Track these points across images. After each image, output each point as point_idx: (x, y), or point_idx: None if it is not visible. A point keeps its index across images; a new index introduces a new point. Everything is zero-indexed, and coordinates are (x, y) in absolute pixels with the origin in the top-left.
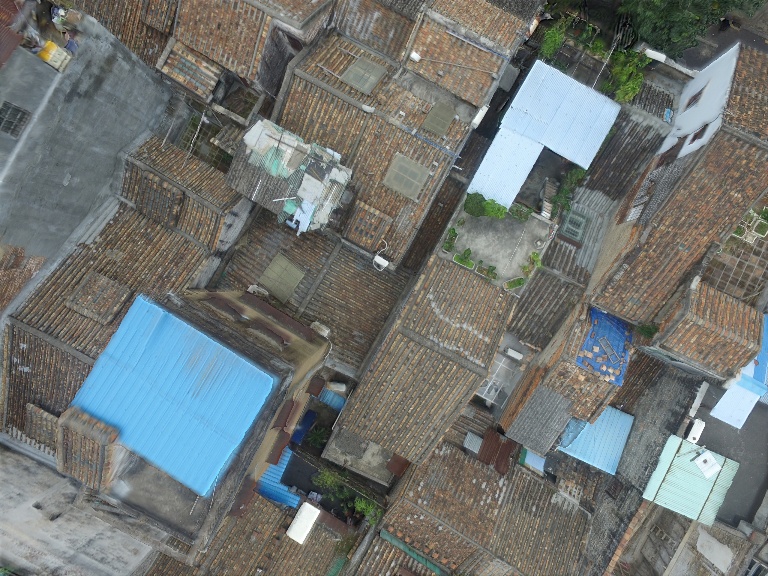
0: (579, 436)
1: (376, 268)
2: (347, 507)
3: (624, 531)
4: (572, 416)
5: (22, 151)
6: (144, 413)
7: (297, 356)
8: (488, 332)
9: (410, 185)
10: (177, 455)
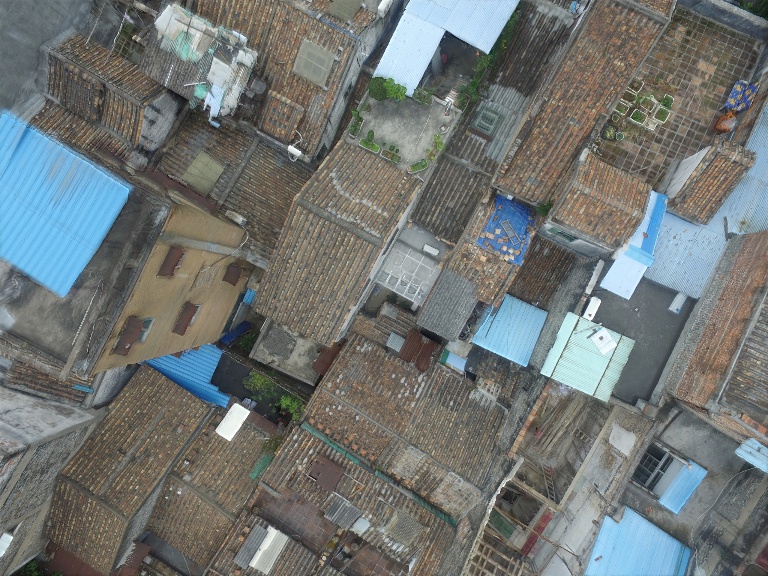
0: (493, 330)
1: (291, 159)
2: (281, 415)
3: (528, 413)
4: (478, 300)
5: None
6: (8, 222)
7: (184, 208)
8: (387, 208)
9: (319, 73)
10: (38, 261)
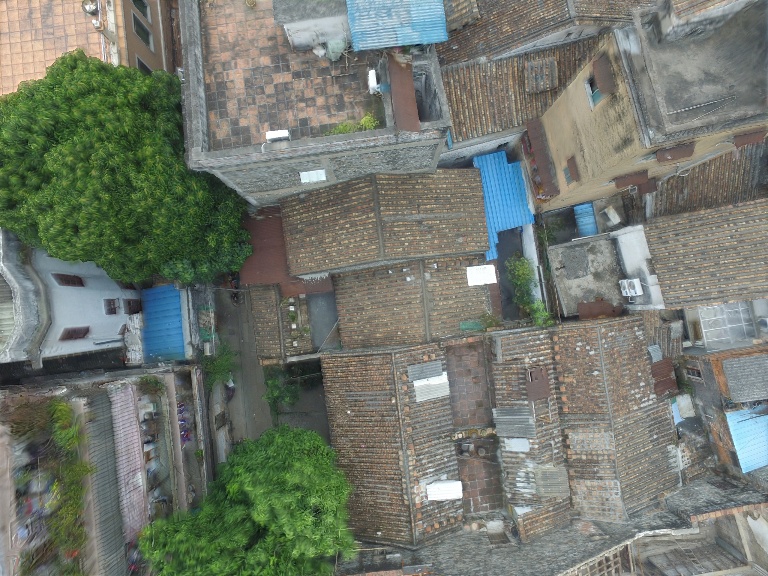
0: (747, 424)
1: None
2: None
3: (736, 506)
4: None
5: None
6: None
7: None
8: None
9: None
10: None
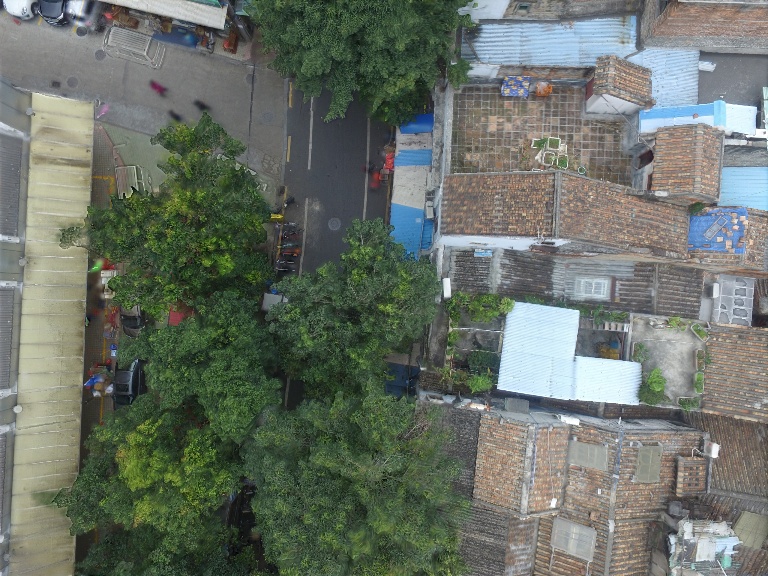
0: (759, 208)
1: None
2: None
3: None
4: None
5: None
6: None
7: None
8: None
9: None
10: None
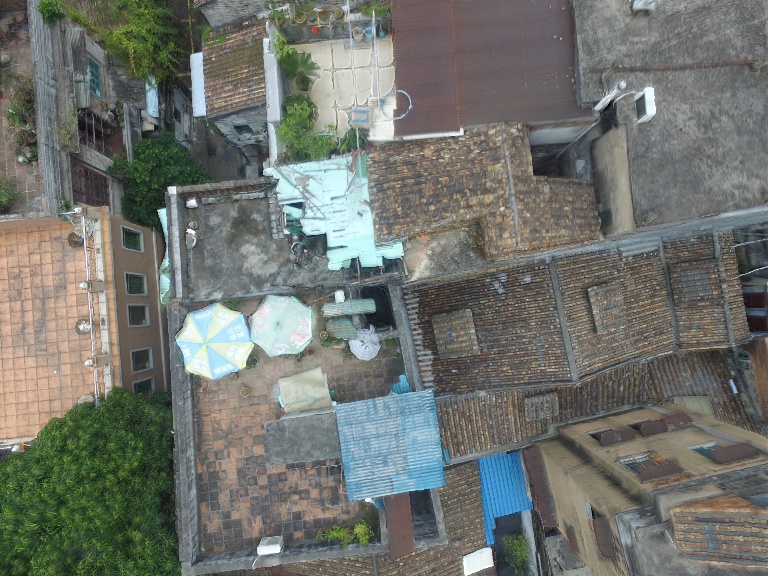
0: None
1: None
2: None
3: None
4: None
5: (765, 211)
6: None
7: None
8: None
9: None
10: None
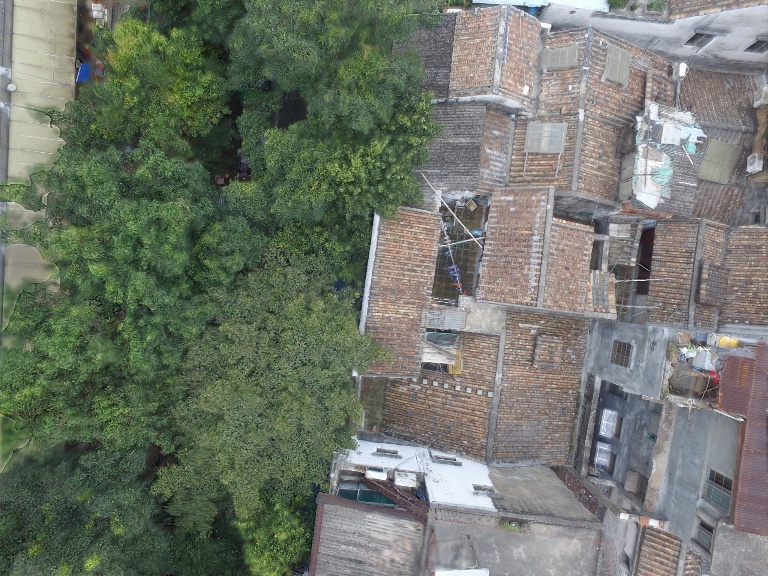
0: None
1: None
2: None
3: None
4: None
5: None
6: None
7: None
8: None
9: None
10: None
